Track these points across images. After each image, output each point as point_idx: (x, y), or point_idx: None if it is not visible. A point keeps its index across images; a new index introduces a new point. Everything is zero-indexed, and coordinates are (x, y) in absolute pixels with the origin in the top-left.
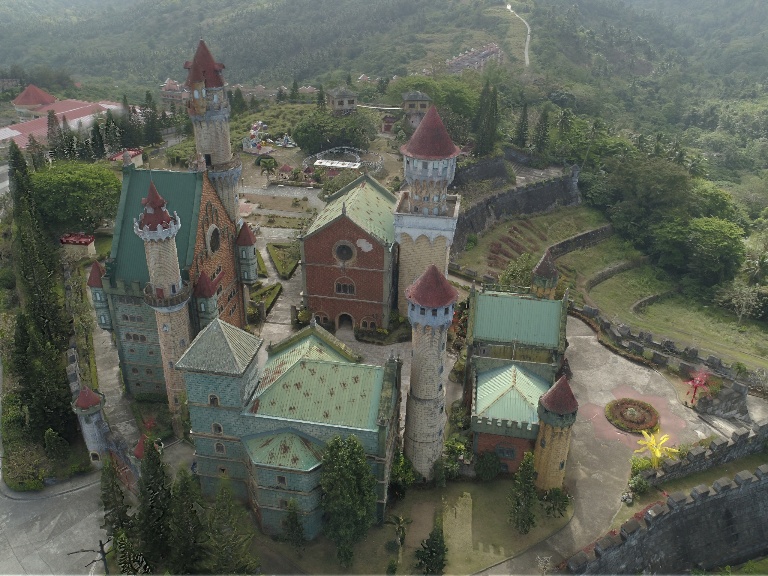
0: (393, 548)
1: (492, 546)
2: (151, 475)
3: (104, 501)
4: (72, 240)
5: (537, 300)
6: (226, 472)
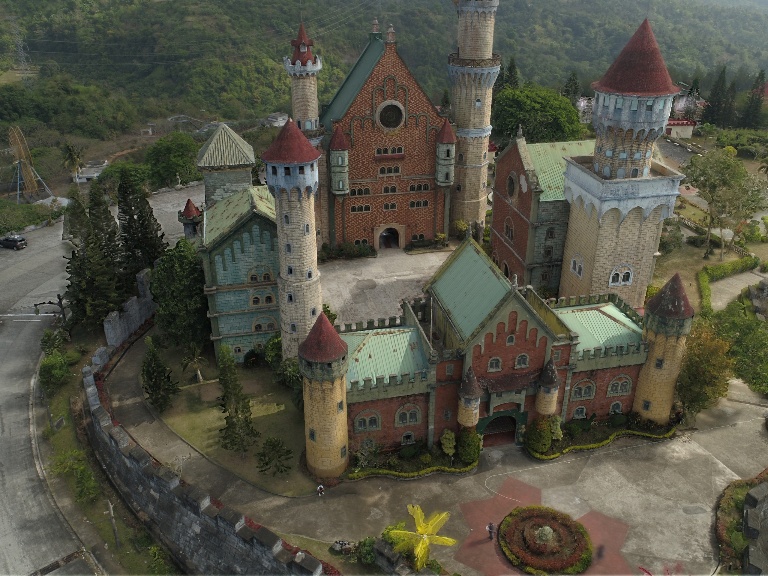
0: (193, 379)
1: (218, 440)
2: (120, 197)
3: None
4: None
5: (497, 277)
6: None
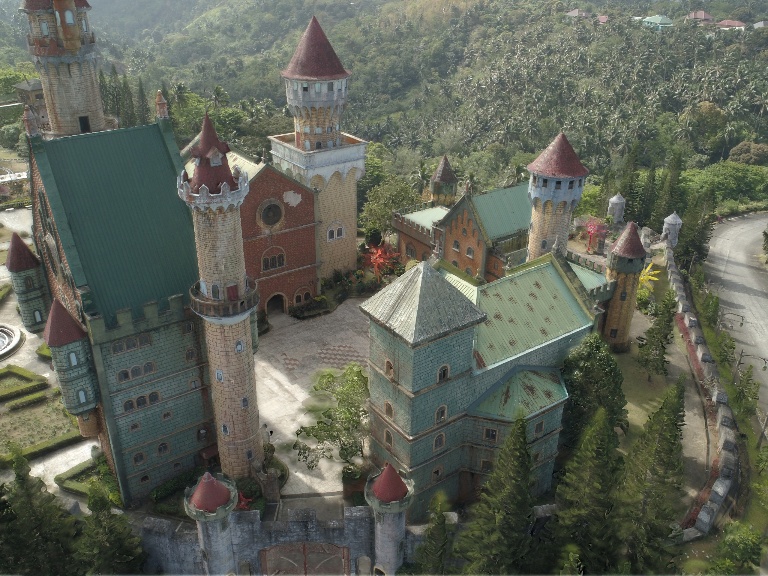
0: None
1: (651, 402)
2: None
3: (435, 568)
4: None
5: (515, 186)
6: (441, 473)
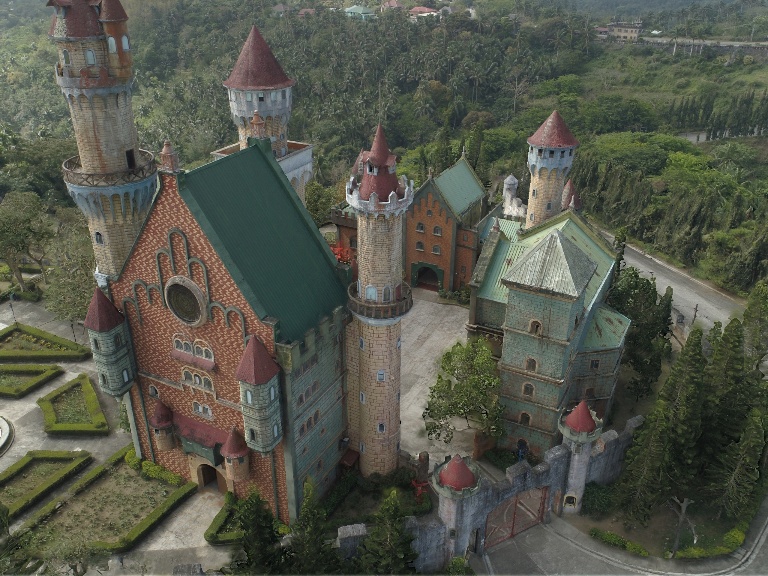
0: None
1: None
2: None
3: None
4: None
5: (455, 166)
6: None
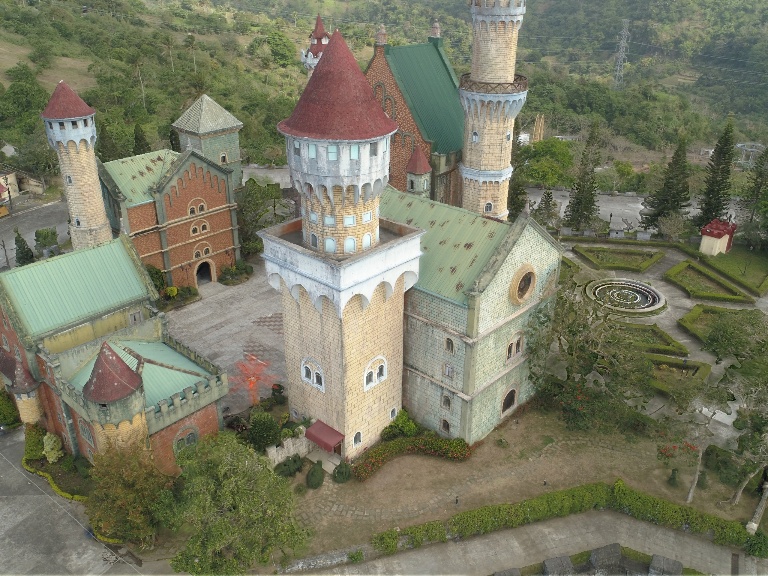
0: None
1: None
2: None
3: None
4: (710, 223)
5: (36, 264)
6: None
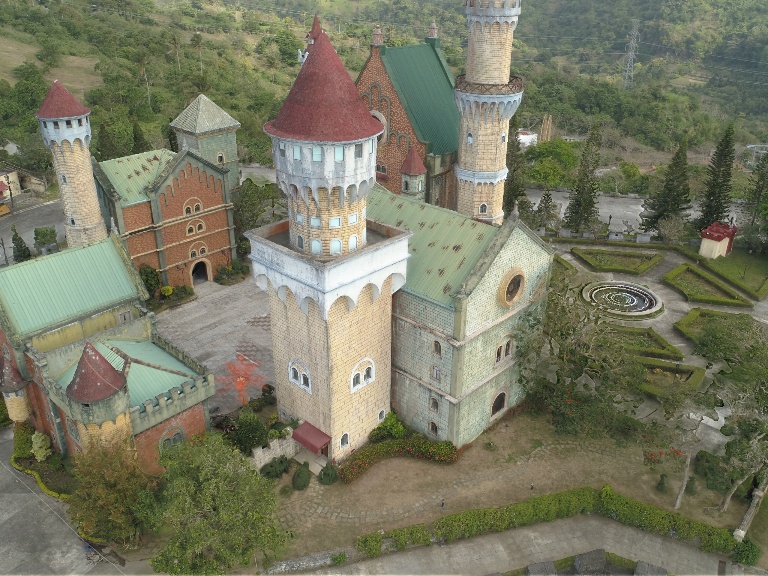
0: None
1: None
2: None
3: None
4: (710, 226)
5: (25, 263)
6: None
